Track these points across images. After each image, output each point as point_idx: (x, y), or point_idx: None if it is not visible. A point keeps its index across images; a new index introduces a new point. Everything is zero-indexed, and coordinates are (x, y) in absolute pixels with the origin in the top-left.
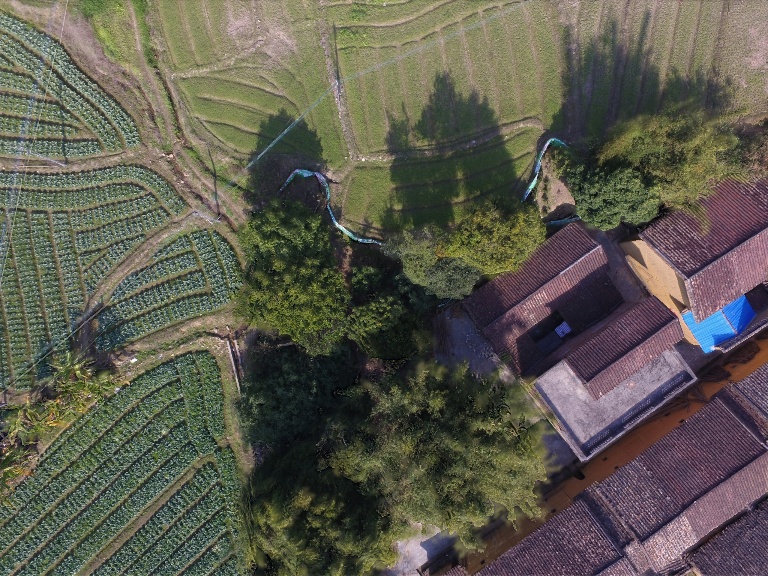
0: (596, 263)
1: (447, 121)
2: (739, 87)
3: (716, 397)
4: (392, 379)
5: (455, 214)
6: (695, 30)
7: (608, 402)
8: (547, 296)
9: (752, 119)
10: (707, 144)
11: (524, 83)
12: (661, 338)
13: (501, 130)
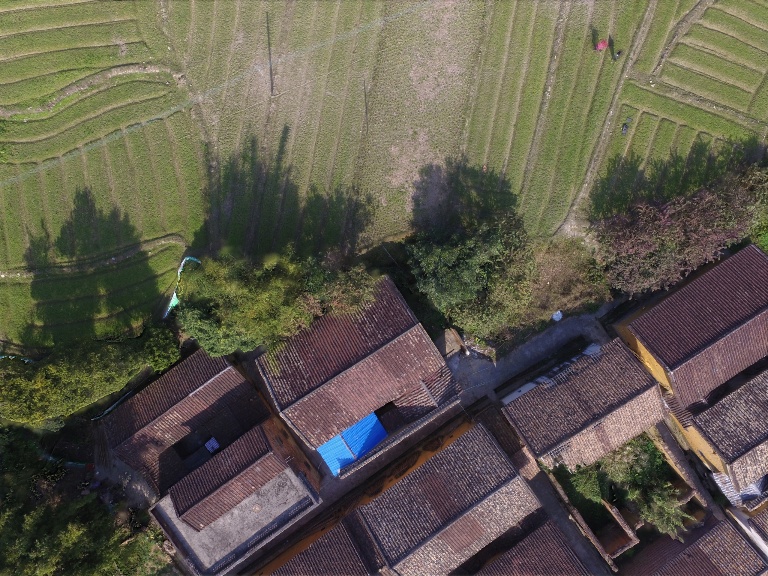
0: (232, 382)
1: (87, 238)
2: (379, 206)
3: (340, 522)
4: (53, 491)
5: (97, 330)
6: (335, 149)
7: (233, 526)
8: (181, 416)
9: (392, 238)
10: (256, 291)
11: (165, 200)
12: (259, 470)
13: (141, 247)
